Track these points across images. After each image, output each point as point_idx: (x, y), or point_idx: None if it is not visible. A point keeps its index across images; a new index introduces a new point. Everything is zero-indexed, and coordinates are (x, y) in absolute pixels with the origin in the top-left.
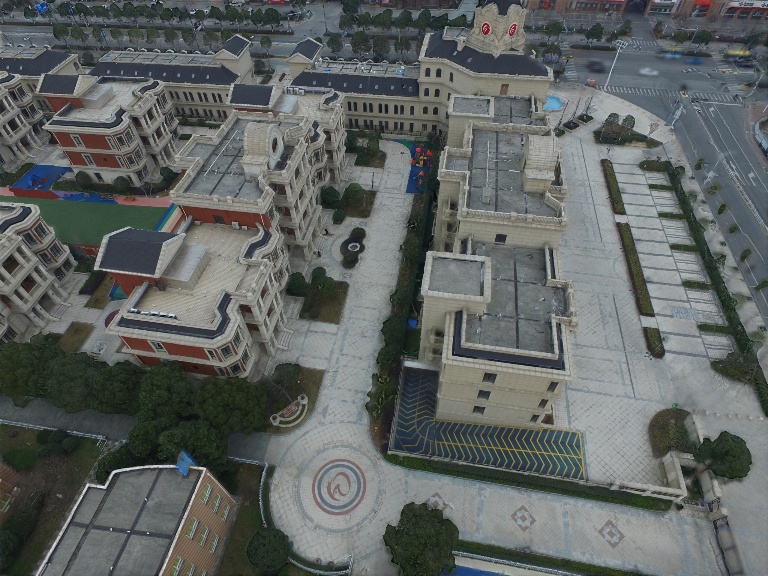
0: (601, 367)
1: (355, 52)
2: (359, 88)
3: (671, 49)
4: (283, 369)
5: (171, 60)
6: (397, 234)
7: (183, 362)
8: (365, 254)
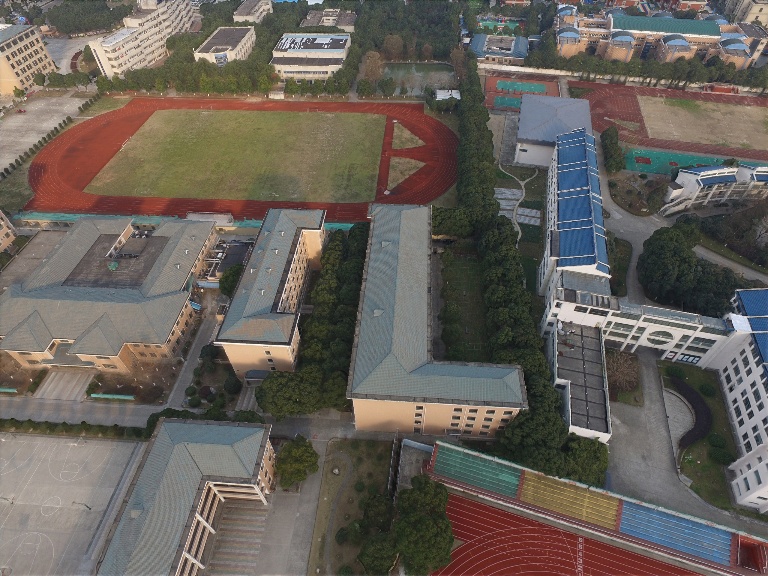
0: None
1: None
2: None
3: None
4: None
5: None
6: (710, 11)
7: None
8: None
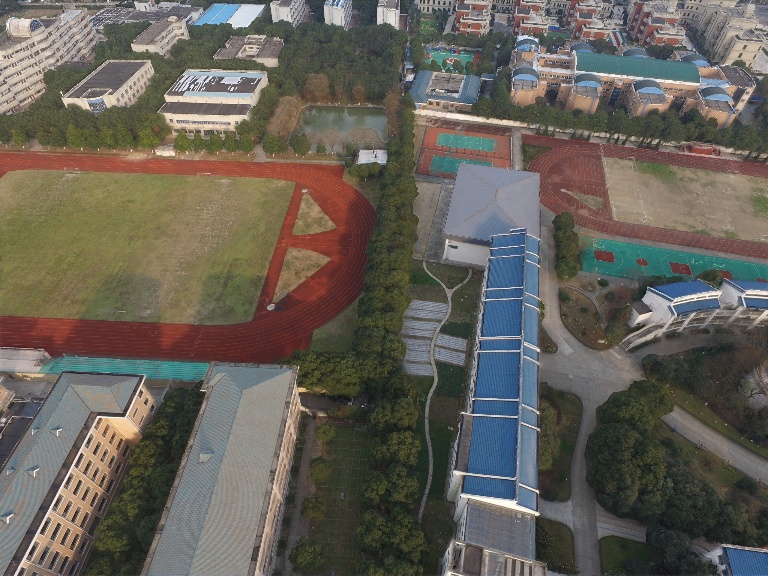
0: None
1: None
2: None
3: (765, 8)
4: None
5: None
6: None
7: None
8: None
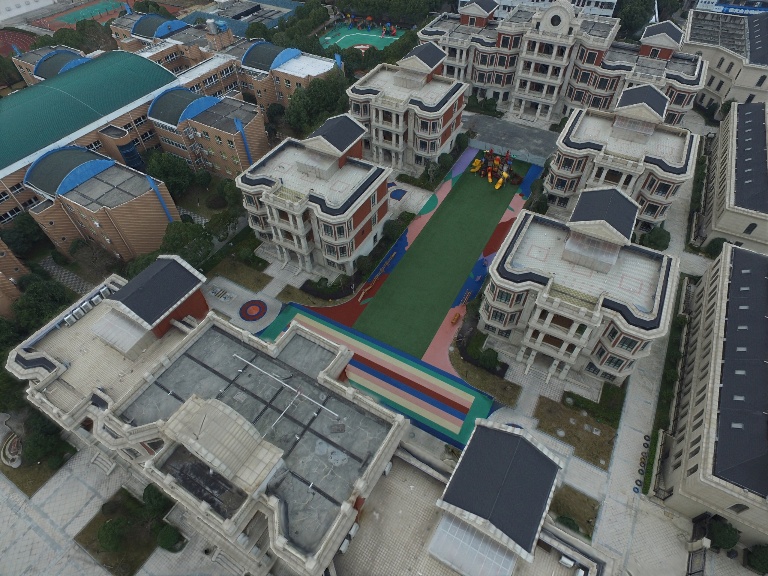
0: None
1: None
2: None
3: None
4: (29, 439)
5: None
6: None
7: None
8: None
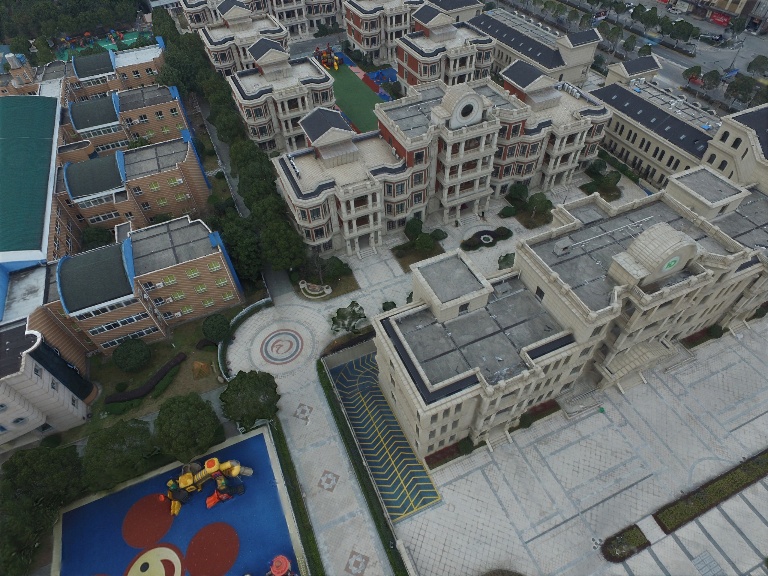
0: (535, 494)
1: (726, 97)
2: (650, 121)
3: None
4: (332, 259)
5: (528, 30)
6: None
7: (288, 206)
8: (487, 250)
